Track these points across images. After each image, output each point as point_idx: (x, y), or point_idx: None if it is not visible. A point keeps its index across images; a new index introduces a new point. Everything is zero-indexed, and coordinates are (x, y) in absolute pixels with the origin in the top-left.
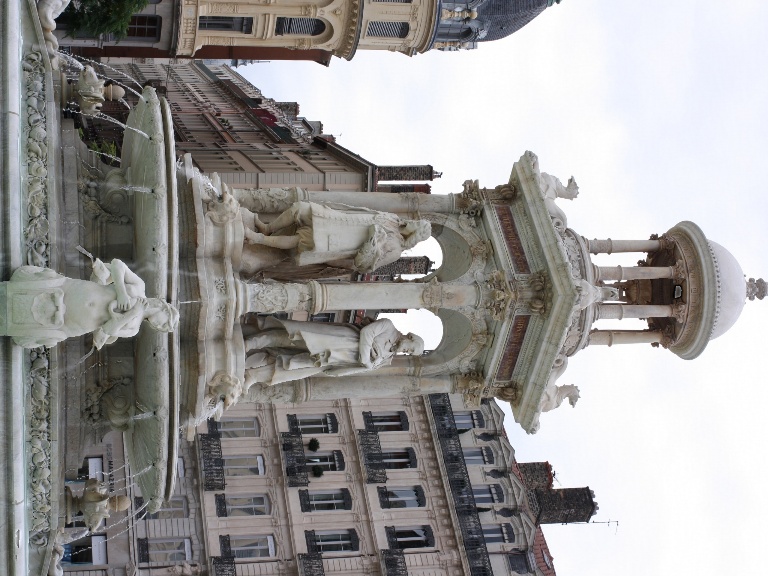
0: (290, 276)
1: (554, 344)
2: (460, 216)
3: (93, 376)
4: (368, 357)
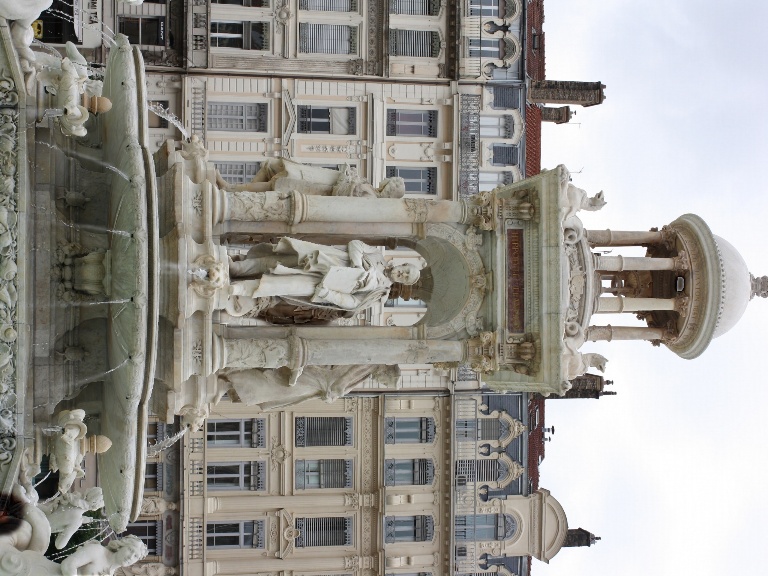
0: None
1: (554, 245)
2: None
3: (64, 230)
4: (360, 263)
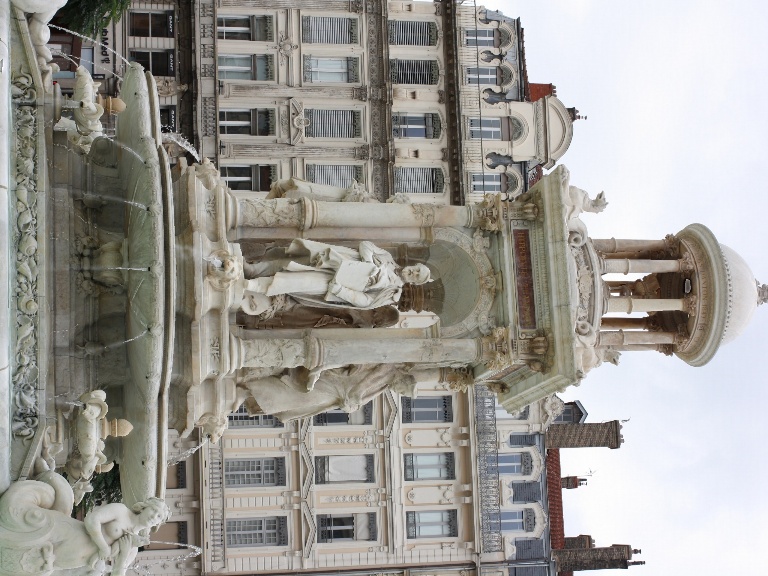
0: (288, 327)
1: (560, 240)
2: None
3: (82, 225)
4: None
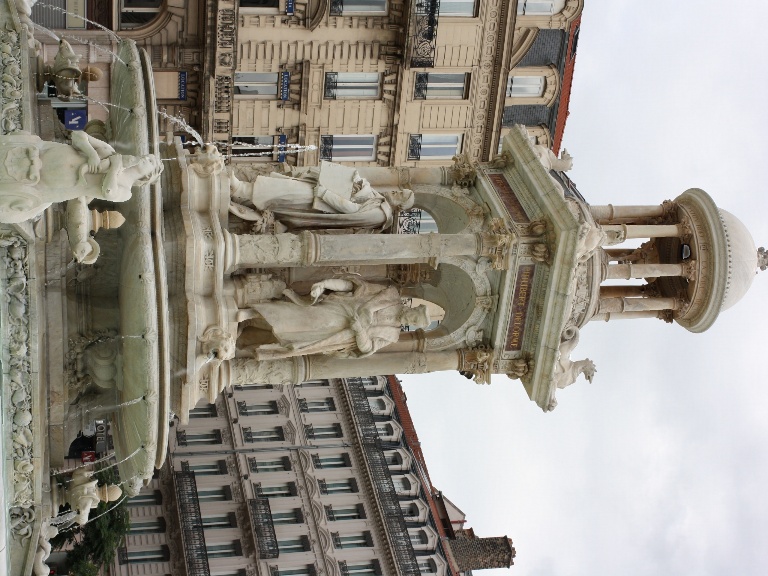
0: None
1: (532, 160)
2: None
3: None
4: None
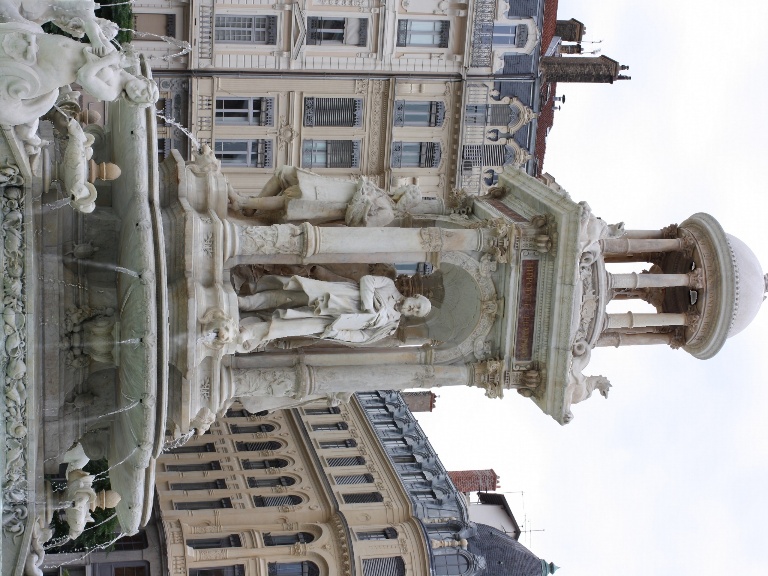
0: None
1: (568, 283)
2: (451, 214)
3: (72, 295)
4: (371, 305)
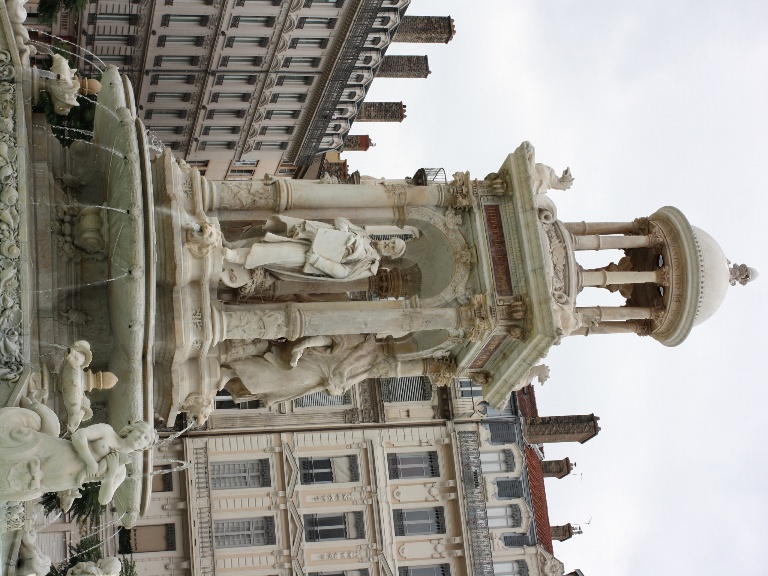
0: None
1: (529, 209)
2: None
3: None
4: None
